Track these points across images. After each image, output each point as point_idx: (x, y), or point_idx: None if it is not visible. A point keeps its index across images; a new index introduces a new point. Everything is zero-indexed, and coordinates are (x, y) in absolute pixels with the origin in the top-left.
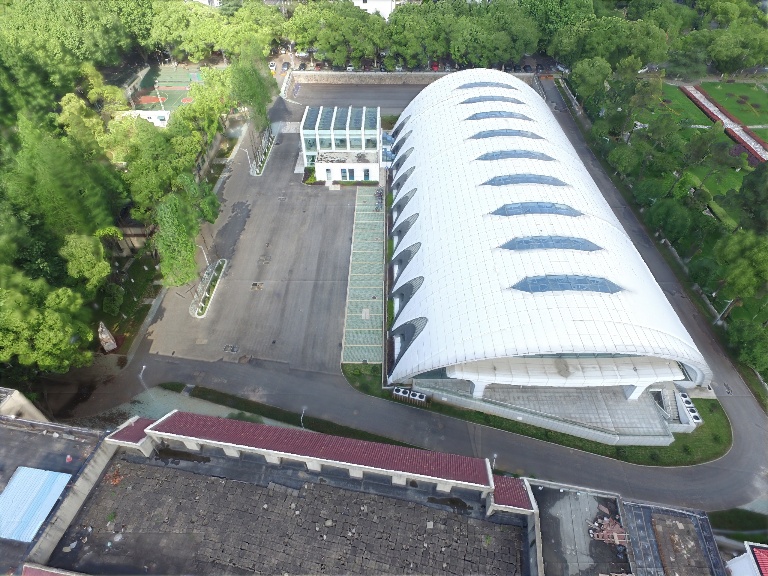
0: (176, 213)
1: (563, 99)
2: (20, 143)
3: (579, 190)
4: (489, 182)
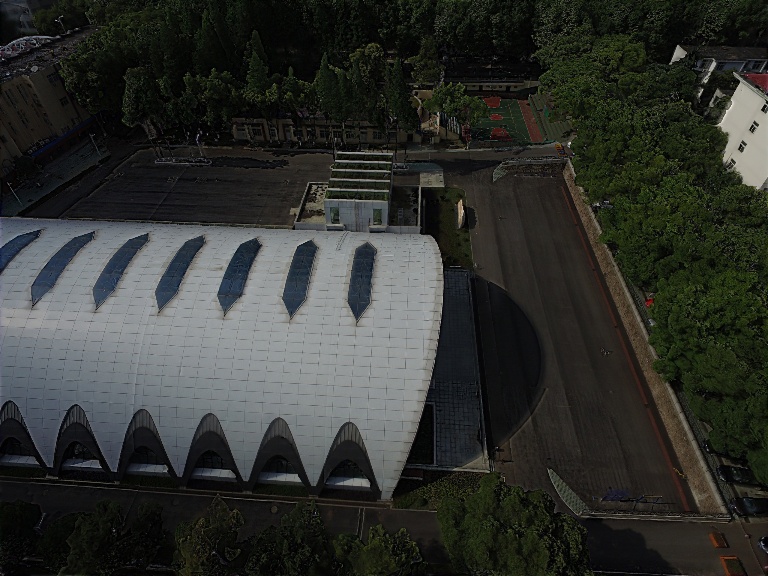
0: (134, 86)
1: (595, 570)
2: (322, 53)
3: (24, 317)
4: (90, 234)
